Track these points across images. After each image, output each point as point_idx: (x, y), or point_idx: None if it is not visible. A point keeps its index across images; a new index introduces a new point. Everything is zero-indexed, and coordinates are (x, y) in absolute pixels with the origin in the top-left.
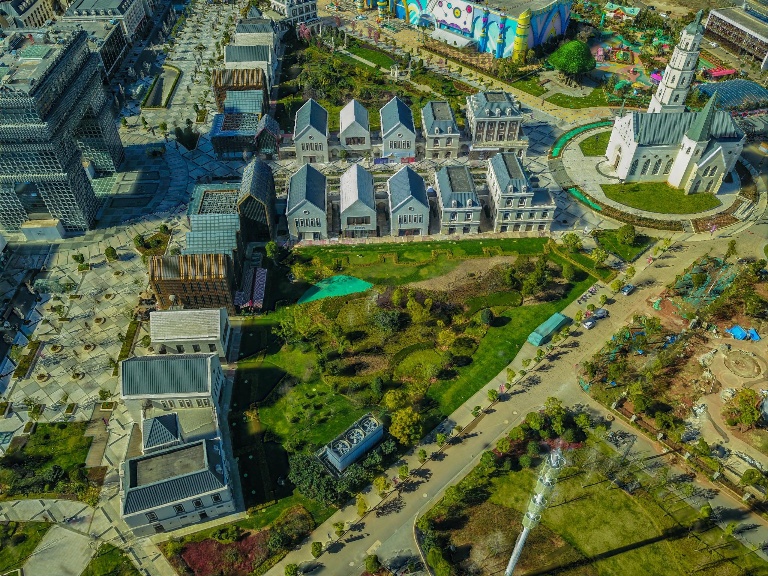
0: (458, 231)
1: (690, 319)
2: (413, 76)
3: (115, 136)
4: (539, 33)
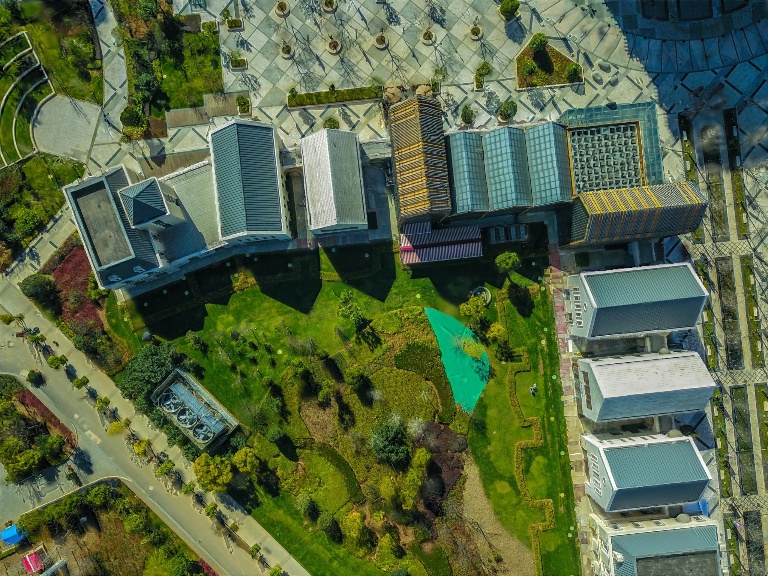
0: (595, 544)
1: None
2: None
3: None
4: None
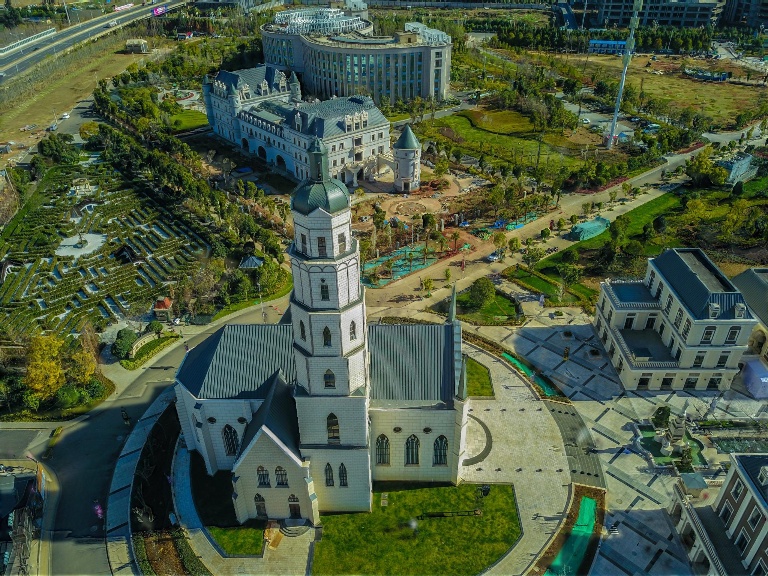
0: None
1: None
2: None
3: None
4: None
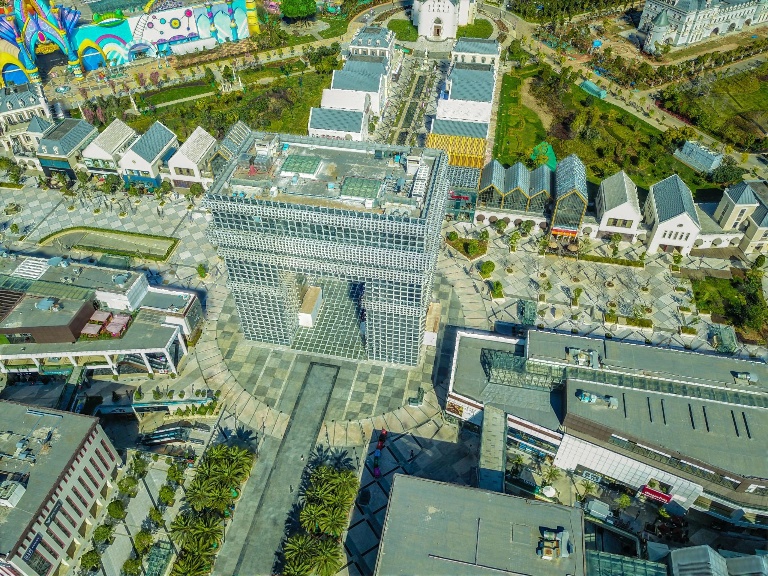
0: None
1: (586, 52)
2: None
3: None
4: None
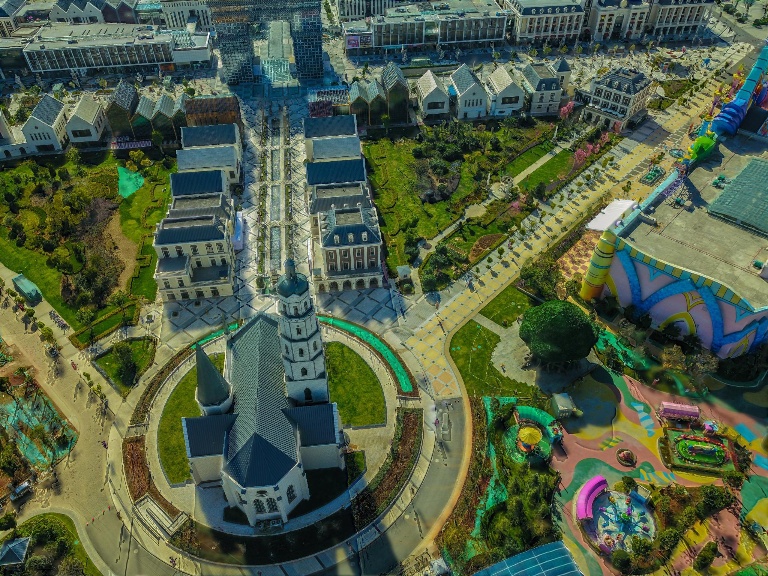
0: None
1: None
2: (503, 200)
3: (316, 58)
4: (648, 293)
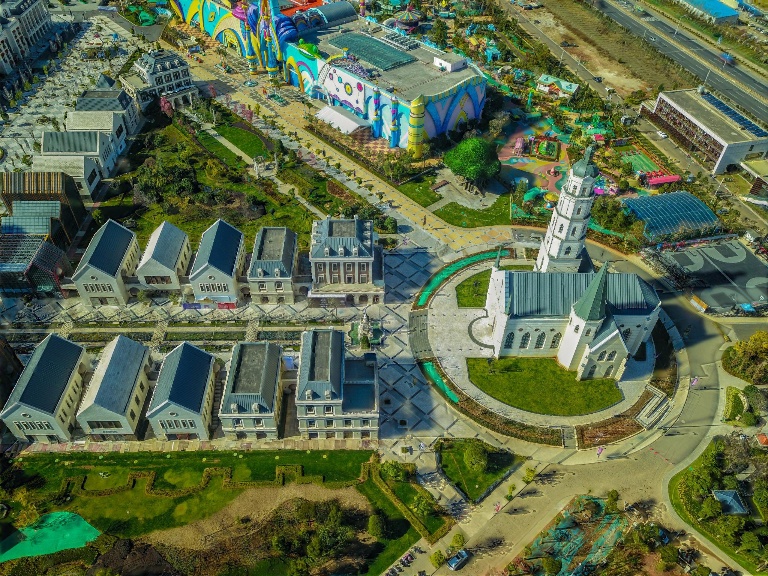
0: (250, 437)
1: None
2: (280, 171)
3: None
4: (442, 119)
